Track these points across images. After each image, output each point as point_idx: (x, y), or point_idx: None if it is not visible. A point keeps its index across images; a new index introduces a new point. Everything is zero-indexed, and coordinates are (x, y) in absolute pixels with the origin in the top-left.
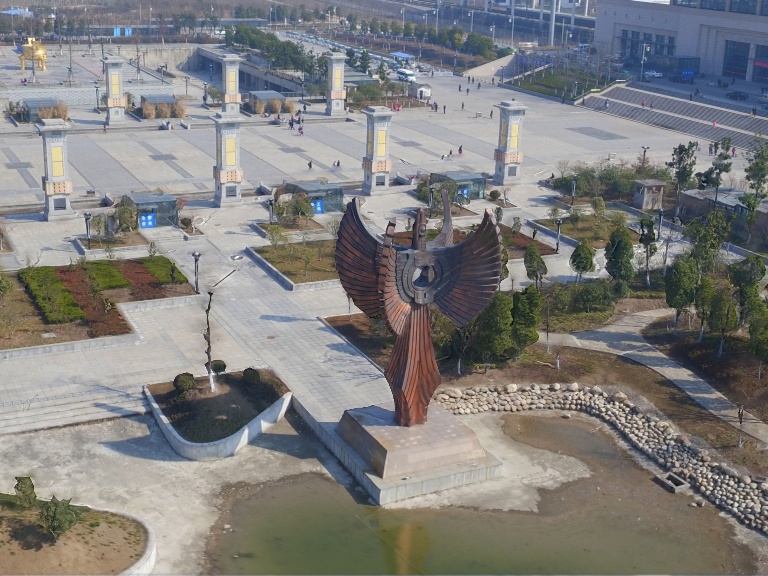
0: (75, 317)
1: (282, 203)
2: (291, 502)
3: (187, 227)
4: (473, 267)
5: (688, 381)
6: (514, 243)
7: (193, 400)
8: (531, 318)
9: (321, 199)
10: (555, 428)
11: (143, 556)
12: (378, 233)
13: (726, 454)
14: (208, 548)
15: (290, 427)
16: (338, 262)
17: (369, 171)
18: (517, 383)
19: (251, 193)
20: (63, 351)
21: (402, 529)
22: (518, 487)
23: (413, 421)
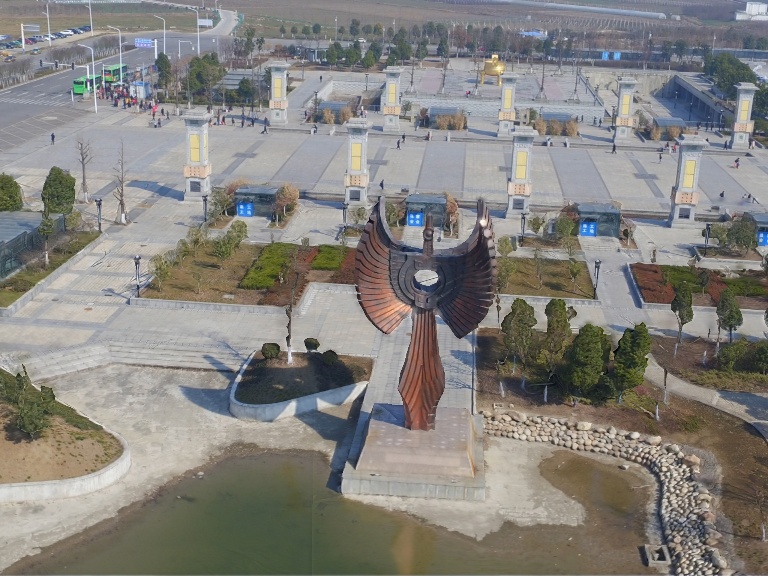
0: (262, 286)
1: (548, 220)
2: (274, 470)
3: None
4: (475, 279)
5: None
6: (766, 293)
7: (268, 367)
8: (632, 358)
9: (595, 222)
10: (598, 474)
11: (95, 472)
12: (628, 262)
13: (739, 544)
14: (166, 485)
15: (347, 412)
16: None
17: (673, 201)
18: (598, 423)
19: (557, 210)
20: (230, 311)
21: (338, 518)
22: (488, 514)
23: (416, 425)
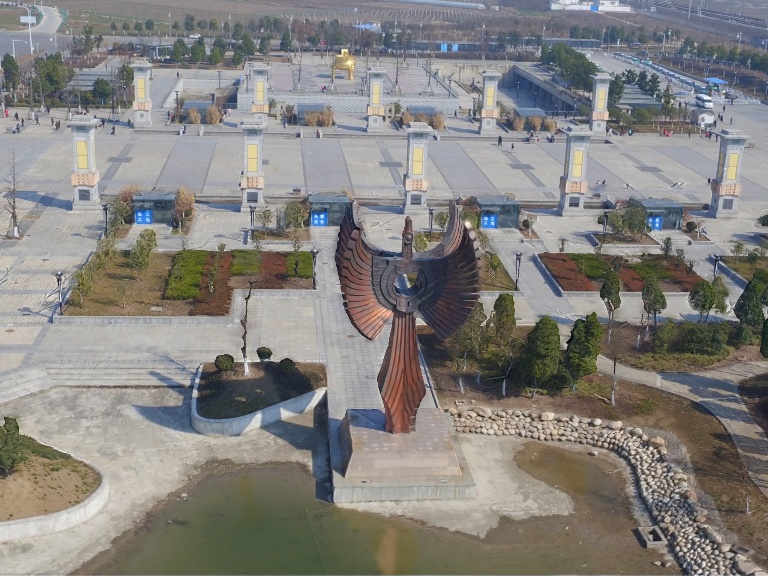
0: (188, 296)
1: None
2: (257, 485)
3: None
4: (458, 281)
5: (749, 438)
6: (671, 276)
7: (225, 380)
8: (586, 347)
9: (496, 214)
10: (572, 463)
11: (79, 503)
12: (536, 252)
13: (726, 518)
14: (153, 510)
15: (311, 419)
16: (337, 263)
17: (563, 191)
18: (559, 412)
19: None
20: (161, 324)
21: (338, 528)
22: (482, 511)
23: (398, 428)
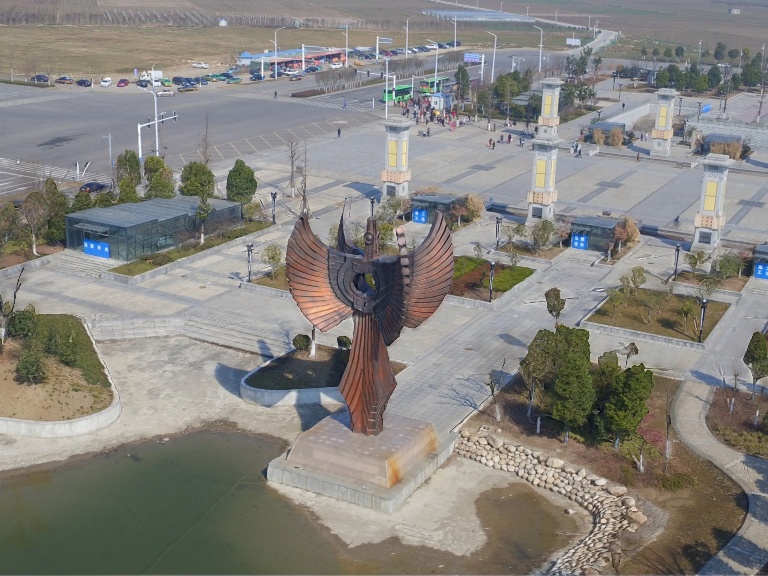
0: None
1: (716, 256)
2: (230, 448)
3: (612, 256)
4: (401, 288)
5: (752, 545)
6: None
7: (293, 357)
8: (622, 400)
9: None
10: (535, 513)
11: (68, 420)
12: None
13: None
14: (129, 443)
15: None
16: None
17: None
18: (575, 463)
19: None
20: None
21: (245, 500)
22: (382, 526)
23: (359, 428)
